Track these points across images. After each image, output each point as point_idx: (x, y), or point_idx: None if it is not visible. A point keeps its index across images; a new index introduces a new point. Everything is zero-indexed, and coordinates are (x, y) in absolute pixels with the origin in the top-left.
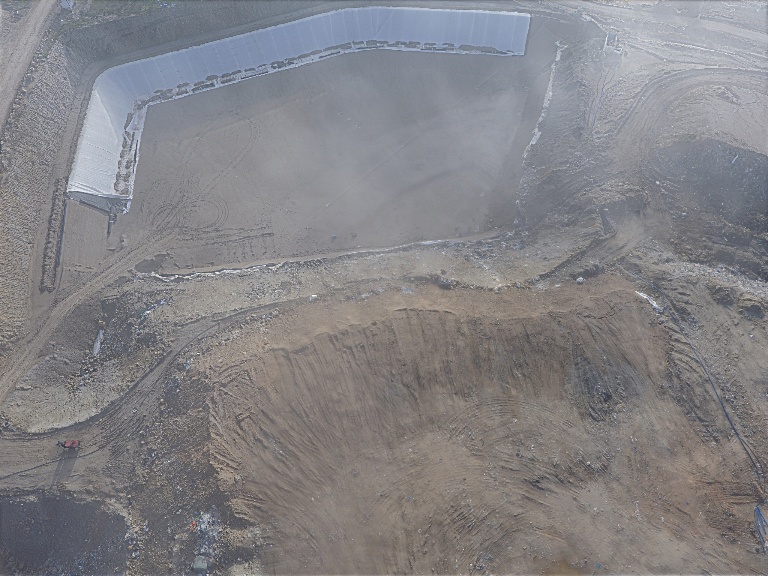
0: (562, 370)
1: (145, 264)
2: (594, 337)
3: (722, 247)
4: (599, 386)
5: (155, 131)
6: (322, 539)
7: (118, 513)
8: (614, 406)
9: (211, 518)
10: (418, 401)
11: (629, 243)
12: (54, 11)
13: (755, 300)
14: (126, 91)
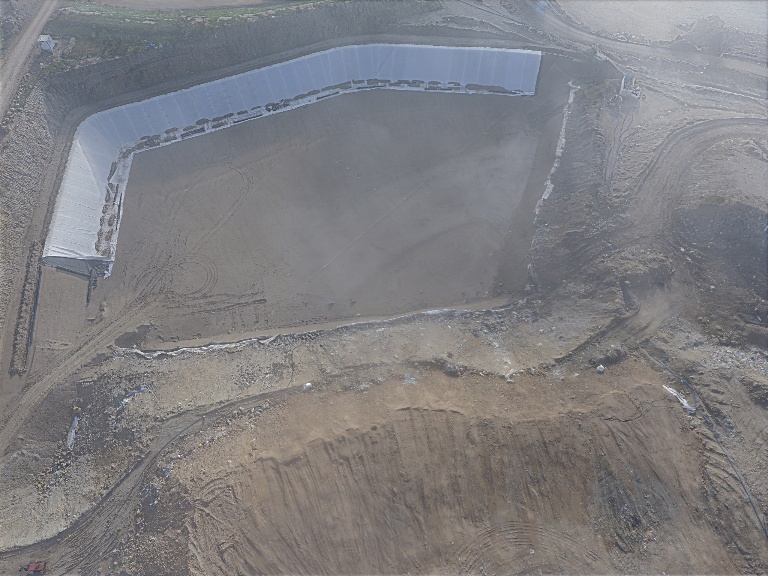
0: (584, 487)
1: (126, 337)
2: (619, 446)
3: (755, 328)
4: (626, 508)
5: (141, 182)
6: None
7: None
8: (643, 533)
9: None
10: (423, 527)
11: (653, 322)
12: (34, 53)
13: None
14: (110, 138)
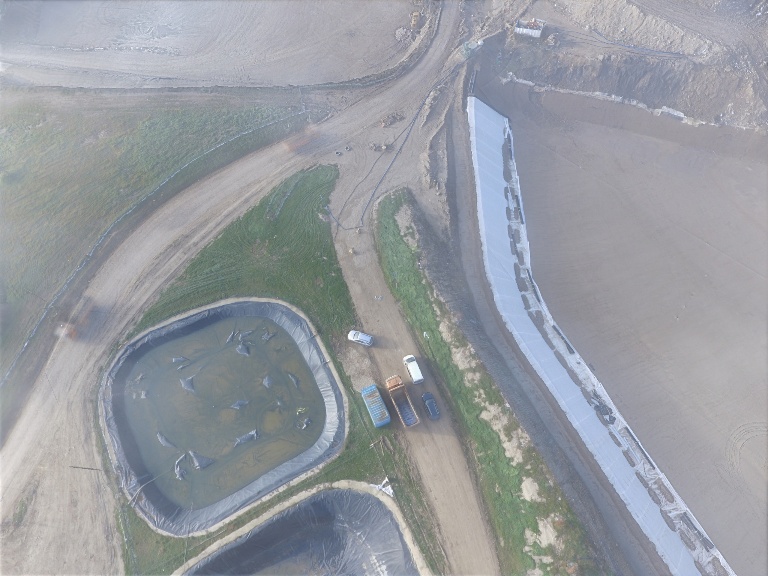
0: None
1: None
2: None
3: None
4: None
5: None
6: None
7: None
8: None
9: None
10: None
11: None
12: None
13: None
14: None
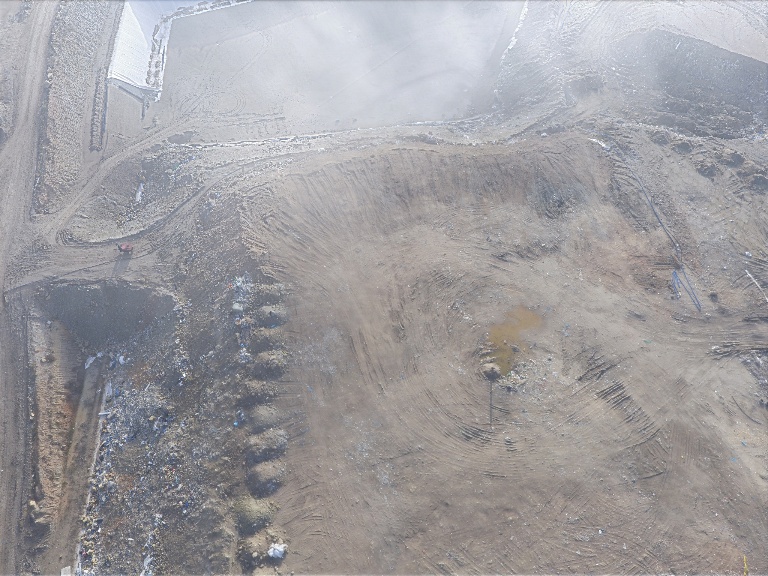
0: (525, 186)
1: (176, 139)
2: (552, 165)
3: (664, 113)
4: (554, 196)
5: (180, 39)
6: (332, 290)
7: (167, 294)
8: (566, 209)
9: (245, 279)
10: (408, 205)
11: (587, 111)
12: None
13: (685, 139)
14: (153, 6)
